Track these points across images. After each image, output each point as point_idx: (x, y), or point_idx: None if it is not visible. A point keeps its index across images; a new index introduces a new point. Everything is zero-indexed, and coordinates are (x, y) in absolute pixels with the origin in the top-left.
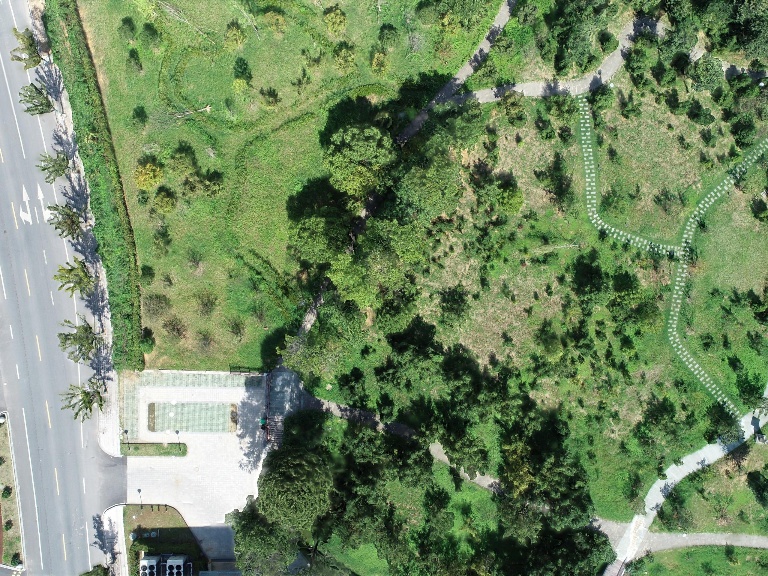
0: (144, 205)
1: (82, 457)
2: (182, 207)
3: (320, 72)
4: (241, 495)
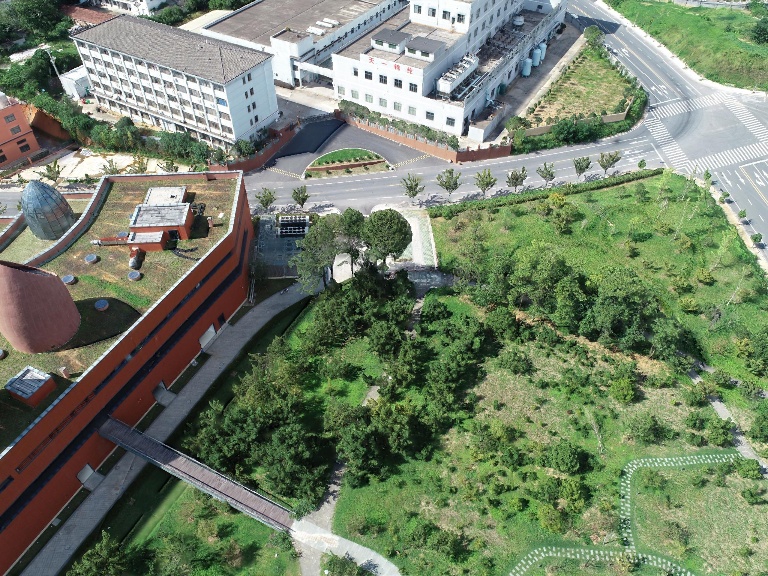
0: (538, 203)
1: (370, 198)
2: (543, 219)
3: (664, 277)
4: (348, 266)
